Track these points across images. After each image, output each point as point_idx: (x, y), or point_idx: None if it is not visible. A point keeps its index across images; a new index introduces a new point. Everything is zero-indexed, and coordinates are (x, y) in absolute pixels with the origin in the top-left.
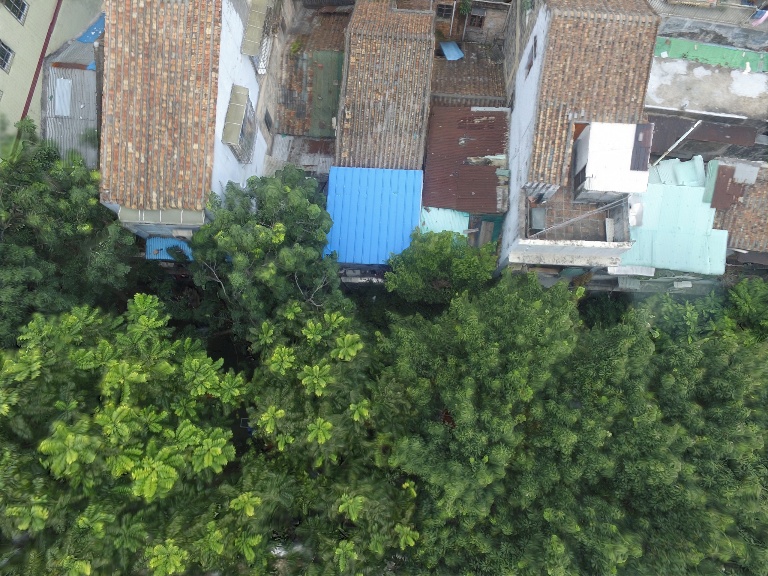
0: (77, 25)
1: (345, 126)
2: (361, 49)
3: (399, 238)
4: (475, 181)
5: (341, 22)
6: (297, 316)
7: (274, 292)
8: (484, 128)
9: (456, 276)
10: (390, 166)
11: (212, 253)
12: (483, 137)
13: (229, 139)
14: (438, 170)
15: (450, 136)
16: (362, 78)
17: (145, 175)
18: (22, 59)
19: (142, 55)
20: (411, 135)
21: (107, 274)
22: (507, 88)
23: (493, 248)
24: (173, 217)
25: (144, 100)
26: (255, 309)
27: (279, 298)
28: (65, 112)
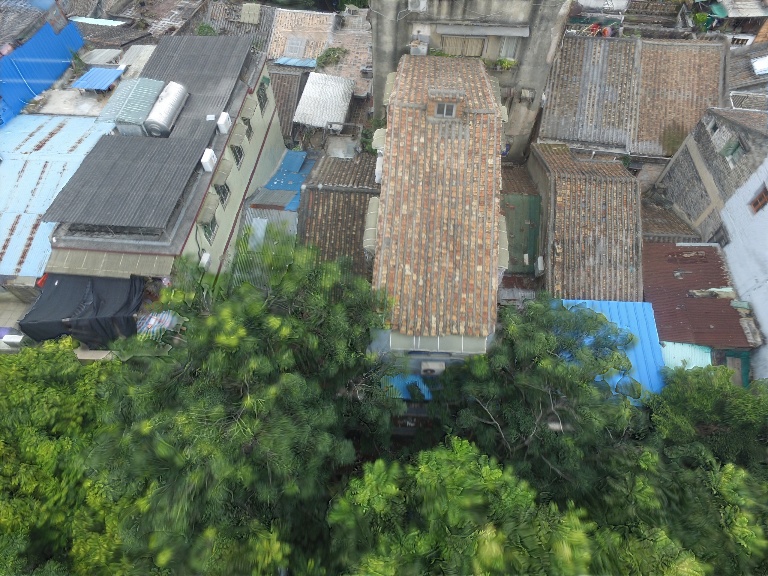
0: (264, 175)
1: (557, 260)
2: (566, 190)
3: (644, 375)
4: (709, 314)
5: (510, 174)
6: (646, 464)
7: (588, 434)
8: (697, 262)
9: (737, 419)
10: (608, 299)
11: (488, 387)
12: (699, 271)
13: (500, 263)
14: (661, 303)
15: (663, 270)
16: (569, 215)
17: (423, 298)
18: (233, 199)
19: (422, 183)
20: (627, 268)
21: (370, 412)
22: (697, 227)
23: (767, 386)
24: (453, 344)
25: (424, 223)
26: (571, 456)
27: (595, 442)
28: (258, 248)
